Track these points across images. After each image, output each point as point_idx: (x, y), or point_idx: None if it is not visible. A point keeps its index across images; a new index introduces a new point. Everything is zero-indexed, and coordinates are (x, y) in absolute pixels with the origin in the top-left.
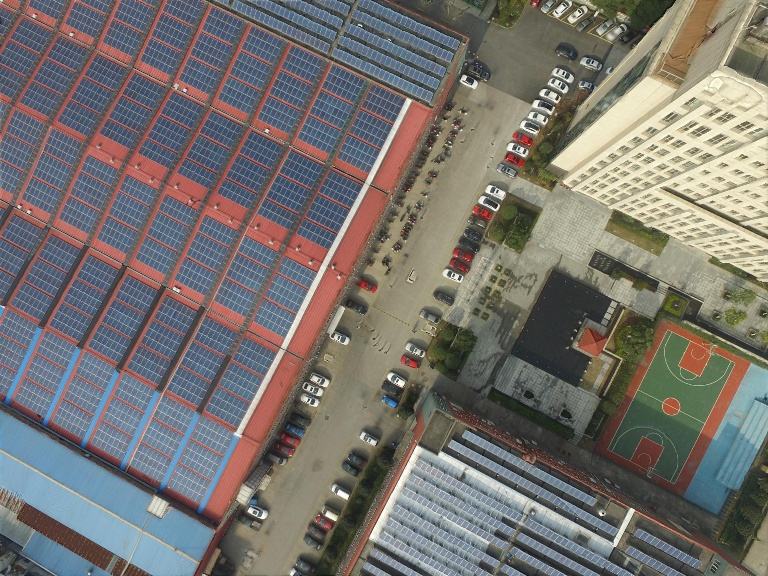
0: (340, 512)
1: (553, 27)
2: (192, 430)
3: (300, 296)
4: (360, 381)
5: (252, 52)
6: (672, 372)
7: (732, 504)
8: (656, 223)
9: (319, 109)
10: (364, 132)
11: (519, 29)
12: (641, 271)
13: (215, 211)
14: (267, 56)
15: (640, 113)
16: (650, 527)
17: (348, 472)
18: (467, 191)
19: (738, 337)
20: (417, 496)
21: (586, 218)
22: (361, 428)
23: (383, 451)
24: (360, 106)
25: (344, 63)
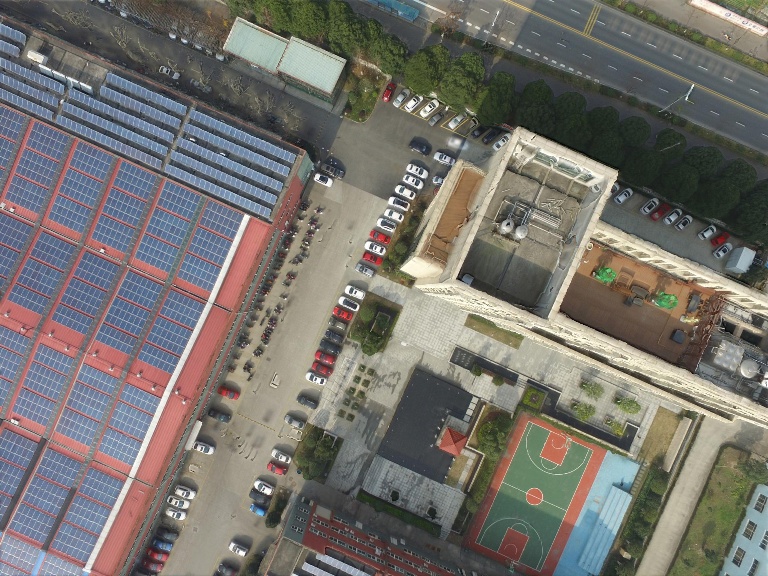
0: None
1: (406, 121)
2: (38, 568)
3: (145, 423)
4: (227, 490)
5: (81, 169)
6: (534, 463)
7: None
8: None
9: (155, 227)
10: (204, 250)
11: (372, 124)
12: (501, 365)
13: (50, 339)
14: (97, 173)
15: (430, 273)
16: None
17: None
18: (327, 291)
19: (595, 425)
20: None
21: (446, 314)
22: (230, 538)
23: (253, 560)
24: (198, 223)
25: (178, 179)
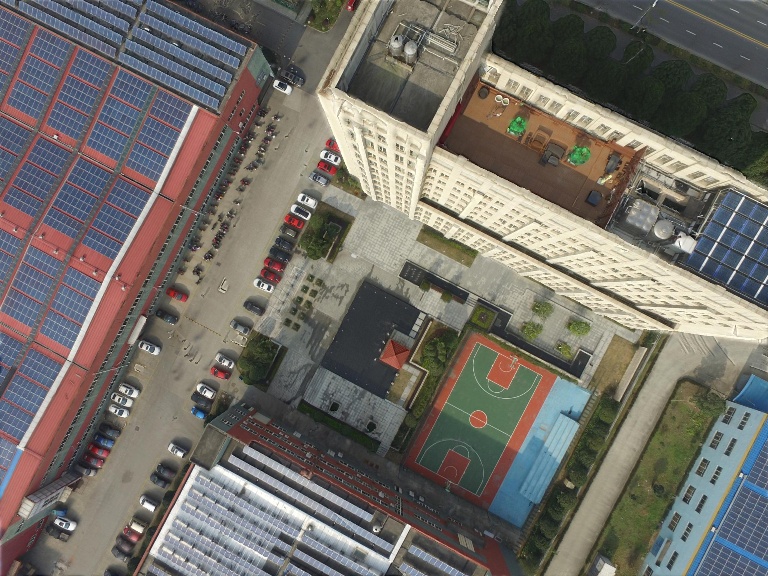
0: (149, 524)
1: None
2: None
3: (85, 307)
4: (170, 392)
5: (40, 55)
6: (480, 385)
7: (536, 517)
8: (449, 235)
9: (107, 115)
10: (152, 139)
11: (335, 33)
12: (451, 282)
13: None
14: (55, 60)
15: None
16: (426, 543)
17: (156, 484)
18: (280, 199)
19: (546, 350)
20: (194, 511)
21: (398, 228)
22: (171, 439)
23: None
24: (148, 113)
25: (131, 68)
